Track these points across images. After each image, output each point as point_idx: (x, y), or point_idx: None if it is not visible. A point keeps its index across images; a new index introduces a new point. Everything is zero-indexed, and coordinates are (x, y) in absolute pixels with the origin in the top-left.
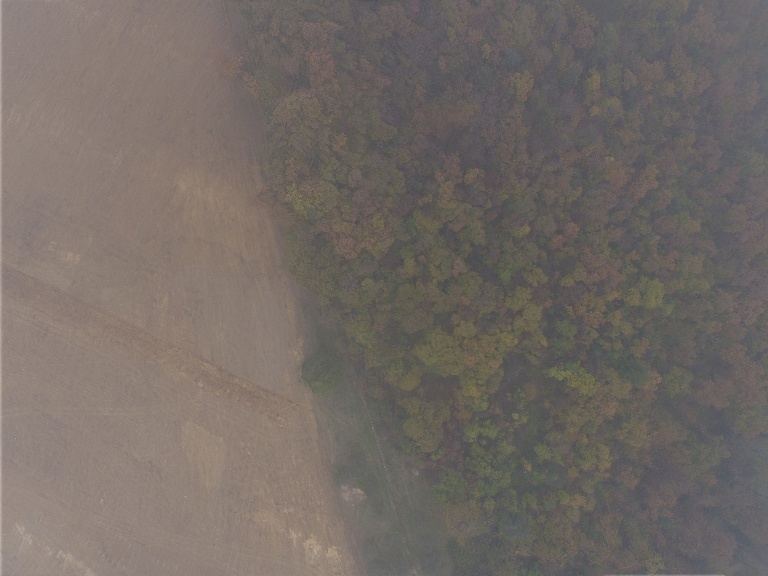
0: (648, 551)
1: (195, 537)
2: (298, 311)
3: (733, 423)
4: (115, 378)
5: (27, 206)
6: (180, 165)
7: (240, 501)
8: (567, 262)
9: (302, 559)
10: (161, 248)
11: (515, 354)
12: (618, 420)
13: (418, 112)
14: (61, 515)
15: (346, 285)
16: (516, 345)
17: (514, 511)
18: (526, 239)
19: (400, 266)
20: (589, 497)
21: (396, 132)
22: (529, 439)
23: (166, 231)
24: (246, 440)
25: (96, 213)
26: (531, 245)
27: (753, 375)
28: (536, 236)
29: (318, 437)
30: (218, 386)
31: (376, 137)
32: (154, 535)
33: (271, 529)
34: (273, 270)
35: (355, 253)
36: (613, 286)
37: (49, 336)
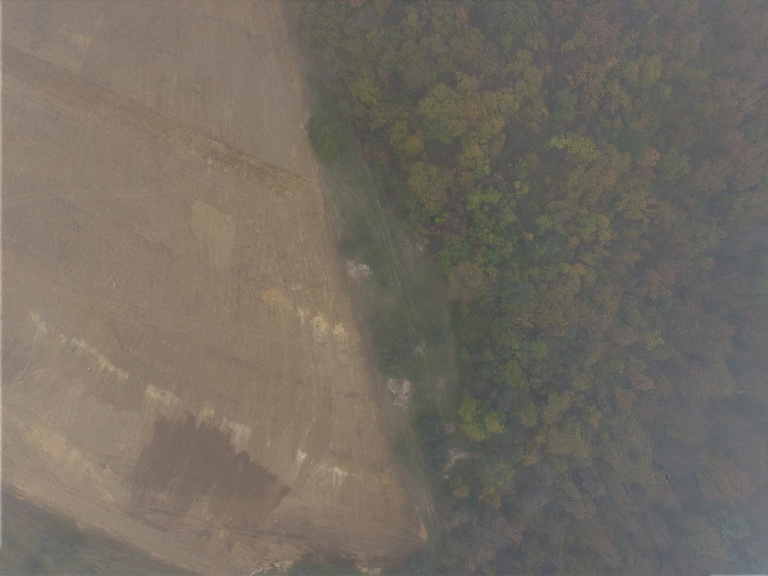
0: (647, 328)
1: (205, 318)
2: (304, 84)
3: (730, 206)
4: (126, 159)
5: None
6: None
7: (249, 280)
8: (567, 28)
9: (310, 337)
10: (170, 26)
11: (517, 122)
12: (618, 194)
13: None
14: (74, 301)
15: (351, 34)
16: (517, 111)
17: (516, 280)
18: (527, 0)
19: (404, 19)
20: (589, 268)
21: None
22: (531, 215)
23: (175, 9)
24: (254, 217)
25: None
26: (532, 4)
27: (750, 154)
28: (537, 1)
29: (325, 212)
30: (227, 163)
31: None
32: (165, 318)
33: (279, 307)
34: (279, 44)
35: (360, 0)
36: (612, 52)
37: (61, 119)
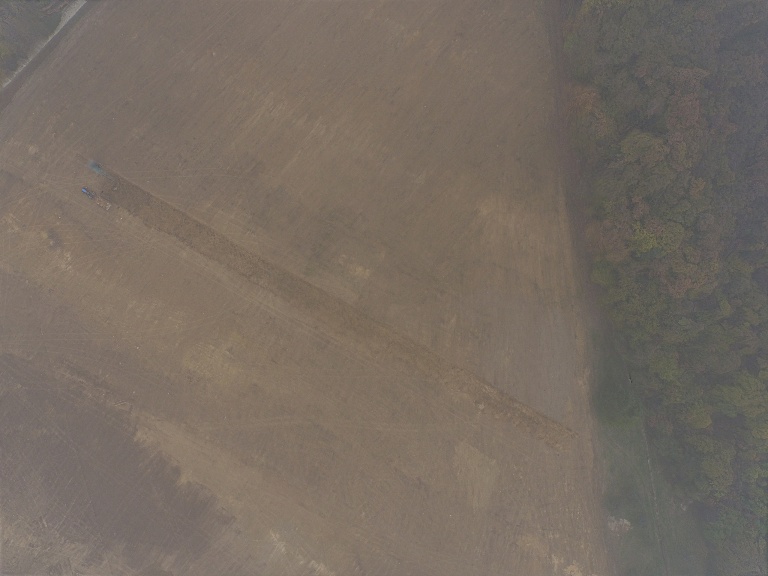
0: None
1: (454, 556)
2: (588, 342)
3: None
4: (393, 394)
5: (320, 218)
6: (484, 190)
7: (506, 524)
8: None
9: None
10: (454, 269)
11: None
12: None
13: (763, 161)
14: (319, 525)
15: (669, 323)
16: None
17: None
18: None
19: (718, 308)
20: None
21: (734, 178)
22: None
23: (461, 253)
24: (520, 464)
25: (391, 230)
26: None
27: None
28: None
29: (593, 466)
30: (499, 409)
31: (722, 182)
32: (413, 551)
33: (534, 553)
34: (567, 300)
35: (683, 293)
36: None
37: (329, 348)
